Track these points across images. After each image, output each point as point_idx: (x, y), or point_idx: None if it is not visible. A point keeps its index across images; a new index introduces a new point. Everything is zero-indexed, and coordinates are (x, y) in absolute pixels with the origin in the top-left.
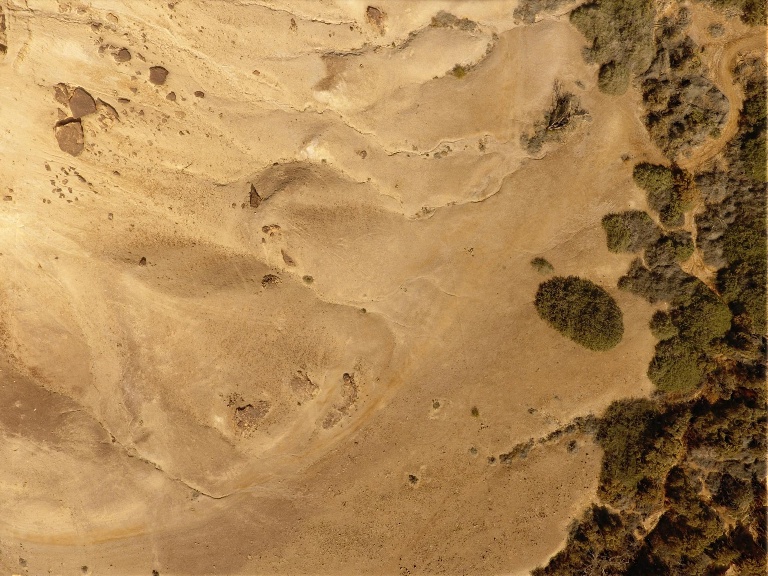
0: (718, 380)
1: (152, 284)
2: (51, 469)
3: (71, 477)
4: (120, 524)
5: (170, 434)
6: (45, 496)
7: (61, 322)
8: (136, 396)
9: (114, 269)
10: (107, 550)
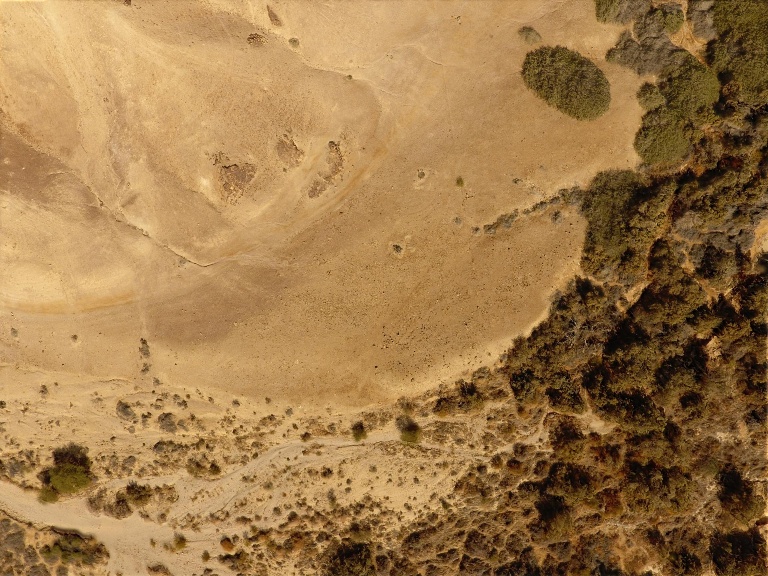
0: (704, 149)
1: (137, 25)
2: (40, 230)
3: (60, 239)
4: (109, 292)
5: (157, 196)
6: (35, 259)
7: (47, 69)
8: (123, 156)
9: (99, 5)
10: (96, 318)
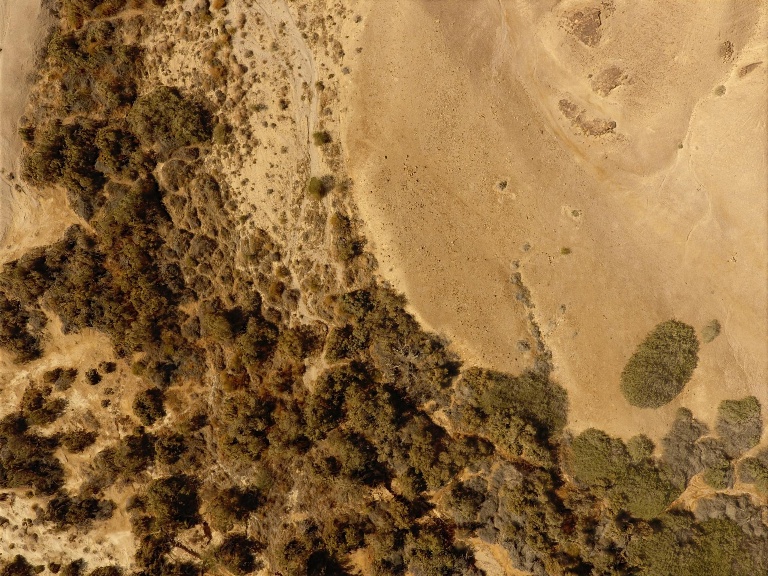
0: None
1: None
2: None
3: None
4: None
5: None
6: None
7: None
8: None
9: None
10: None
